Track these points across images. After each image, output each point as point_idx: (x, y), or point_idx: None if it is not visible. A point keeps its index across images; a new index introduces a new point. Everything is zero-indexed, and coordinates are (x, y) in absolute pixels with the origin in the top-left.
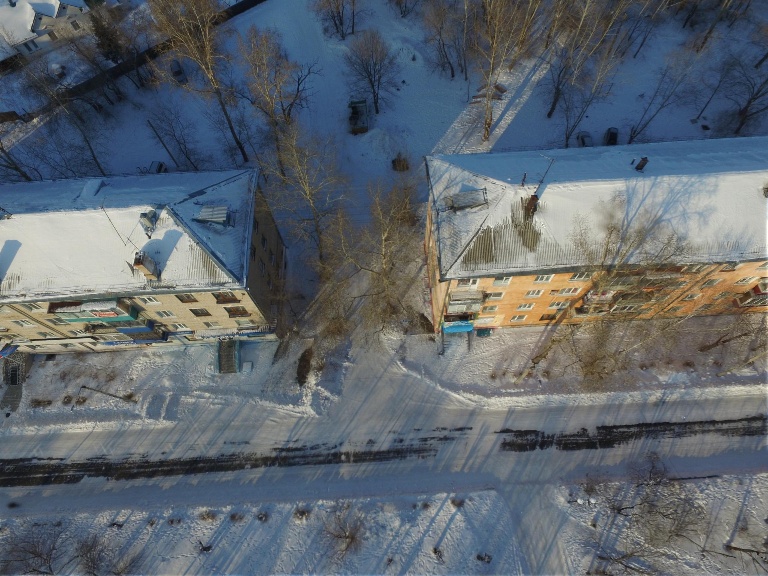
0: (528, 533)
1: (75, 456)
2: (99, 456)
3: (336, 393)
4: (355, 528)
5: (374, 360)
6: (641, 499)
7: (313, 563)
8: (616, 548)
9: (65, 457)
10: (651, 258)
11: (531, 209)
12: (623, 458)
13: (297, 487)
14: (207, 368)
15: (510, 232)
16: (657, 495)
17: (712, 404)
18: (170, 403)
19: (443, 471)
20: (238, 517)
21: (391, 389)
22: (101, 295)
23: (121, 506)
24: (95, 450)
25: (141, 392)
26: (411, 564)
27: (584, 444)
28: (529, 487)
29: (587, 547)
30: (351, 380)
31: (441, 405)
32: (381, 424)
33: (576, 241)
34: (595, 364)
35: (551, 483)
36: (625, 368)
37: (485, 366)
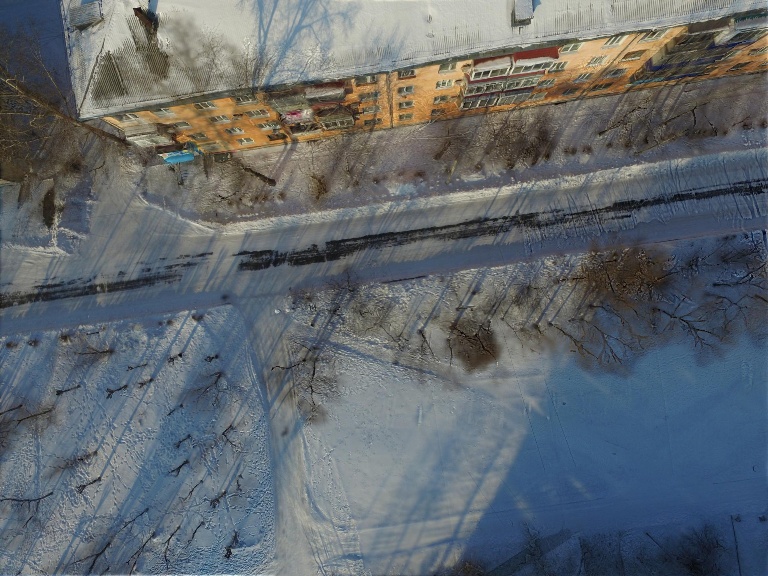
0: (259, 335)
1: None
2: None
3: (83, 232)
4: (113, 344)
5: (117, 196)
6: (355, 301)
7: (82, 372)
8: (330, 340)
9: None
10: (296, 75)
11: (152, 25)
12: (346, 268)
13: (61, 317)
14: None
15: (132, 57)
16: (369, 296)
17: (436, 211)
18: None
19: (187, 292)
20: (13, 345)
21: (136, 223)
22: None
23: None
24: None
25: None
26: (162, 366)
27: (313, 258)
28: (262, 299)
29: (305, 341)
30: (96, 218)
31: (183, 234)
32: (128, 257)
33: (209, 62)
34: (330, 181)
35: (281, 294)
36: (357, 183)
37: (224, 193)
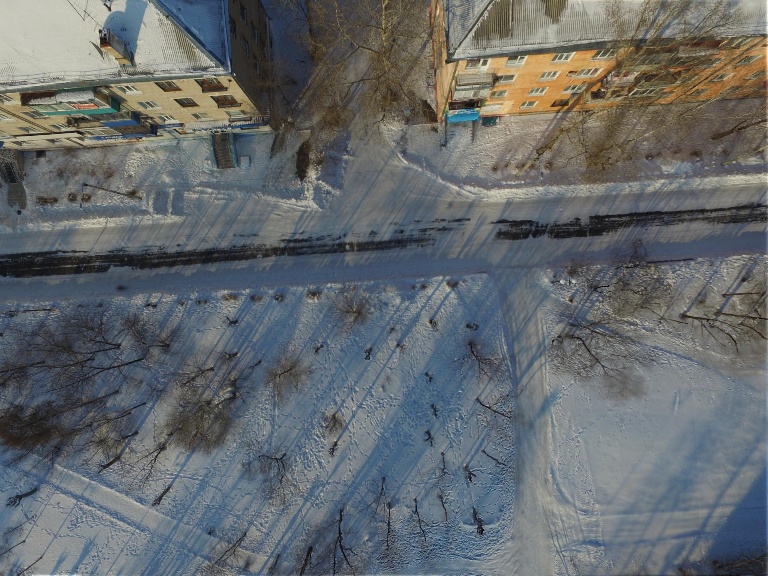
0: (512, 307)
1: (96, 249)
2: (119, 249)
3: (337, 187)
4: (361, 305)
5: (374, 153)
6: (617, 279)
7: (326, 332)
8: (587, 318)
9: (87, 250)
10: (689, 30)
11: None
12: (609, 244)
13: (307, 273)
14: (204, 163)
15: None
16: (633, 276)
17: (708, 193)
18: (174, 199)
19: (440, 258)
20: (257, 298)
21: (392, 182)
22: (74, 84)
23: (151, 290)
24: (113, 243)
25: (143, 188)
26: (410, 332)
27: (575, 232)
28: (518, 270)
29: (562, 317)
30: (352, 174)
31: None
32: (382, 216)
33: (608, 8)
34: (600, 154)
35: (538, 267)
36: (630, 158)
37: (488, 158)
